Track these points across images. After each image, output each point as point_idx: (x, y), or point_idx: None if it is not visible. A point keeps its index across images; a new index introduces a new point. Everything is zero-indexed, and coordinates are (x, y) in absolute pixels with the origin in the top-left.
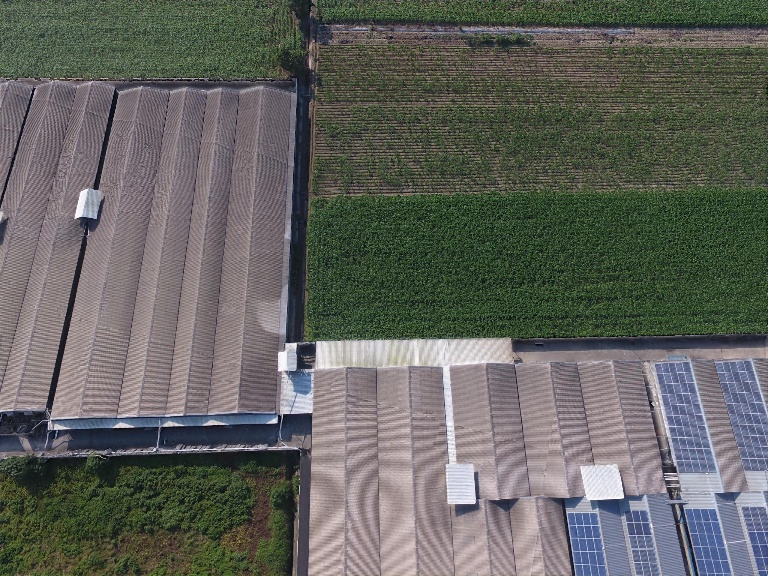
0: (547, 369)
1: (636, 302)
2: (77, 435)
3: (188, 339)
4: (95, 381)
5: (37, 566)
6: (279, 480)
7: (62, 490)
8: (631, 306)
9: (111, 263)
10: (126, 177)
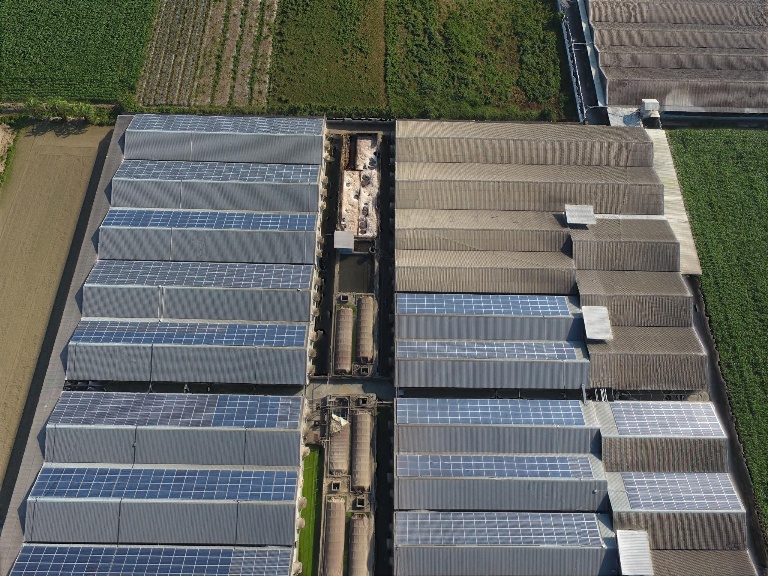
0: (685, 293)
1: (767, 412)
2: (570, 10)
3: (650, 51)
4: (612, 7)
5: (496, 3)
6: (556, 115)
7: (539, 7)
8: (761, 406)
9: (695, 5)
10: (765, 6)
